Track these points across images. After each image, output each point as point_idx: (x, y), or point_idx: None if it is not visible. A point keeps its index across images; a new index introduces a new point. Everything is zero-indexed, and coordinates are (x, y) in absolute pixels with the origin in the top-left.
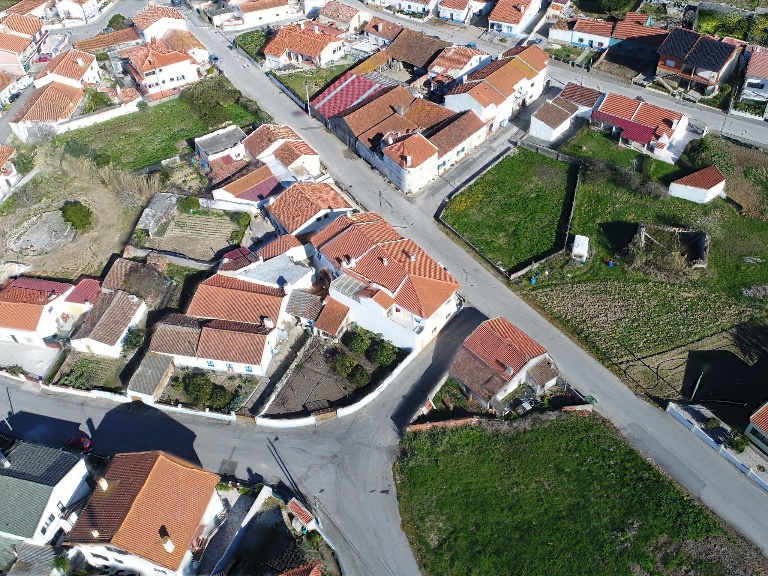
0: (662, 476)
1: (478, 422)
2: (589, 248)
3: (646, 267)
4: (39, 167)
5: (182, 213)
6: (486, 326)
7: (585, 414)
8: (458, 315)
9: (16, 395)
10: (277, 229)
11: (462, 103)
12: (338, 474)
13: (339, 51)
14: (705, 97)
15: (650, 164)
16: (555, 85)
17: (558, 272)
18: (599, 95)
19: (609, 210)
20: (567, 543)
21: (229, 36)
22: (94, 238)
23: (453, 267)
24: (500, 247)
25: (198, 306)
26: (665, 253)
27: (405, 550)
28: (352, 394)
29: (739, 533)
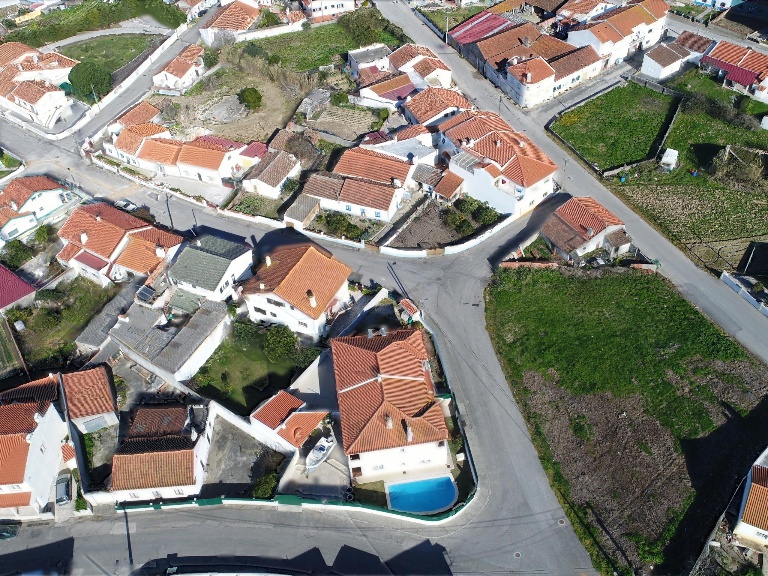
0: (706, 319)
1: (558, 267)
2: (678, 161)
3: (726, 178)
4: (222, 63)
5: (333, 106)
6: (576, 200)
7: (649, 272)
8: (554, 197)
9: (199, 215)
10: (410, 123)
11: (583, 39)
12: (440, 290)
13: None
14: None
15: (748, 102)
16: (672, 35)
17: (646, 175)
18: (711, 43)
19: (702, 135)
20: (617, 351)
21: None
22: (262, 117)
23: None
24: (598, 153)
25: (343, 166)
26: None
27: (486, 342)
28: (458, 240)
29: (762, 362)
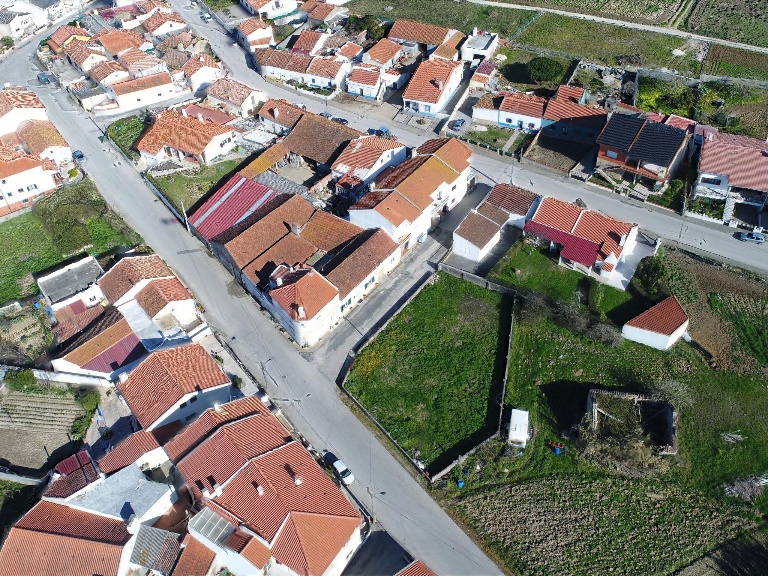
0: None
1: None
2: (529, 425)
3: (602, 454)
4: None
5: (13, 391)
6: None
7: None
8: (364, 546)
9: None
10: None
11: (369, 220)
12: None
13: (228, 143)
14: (654, 193)
15: (597, 293)
16: (481, 181)
17: (492, 466)
18: (532, 200)
19: (551, 364)
20: None
21: (101, 123)
22: None
23: (358, 464)
24: (418, 428)
25: (7, 562)
26: (624, 433)
27: None
28: None
29: None
